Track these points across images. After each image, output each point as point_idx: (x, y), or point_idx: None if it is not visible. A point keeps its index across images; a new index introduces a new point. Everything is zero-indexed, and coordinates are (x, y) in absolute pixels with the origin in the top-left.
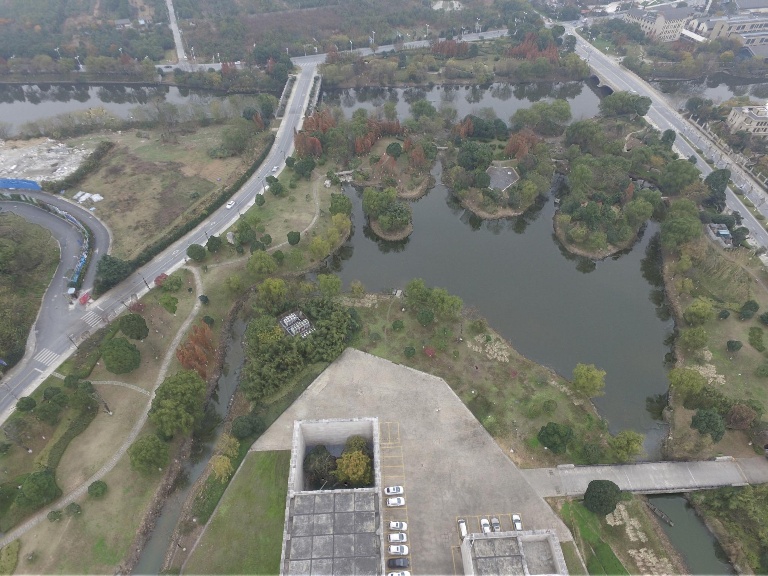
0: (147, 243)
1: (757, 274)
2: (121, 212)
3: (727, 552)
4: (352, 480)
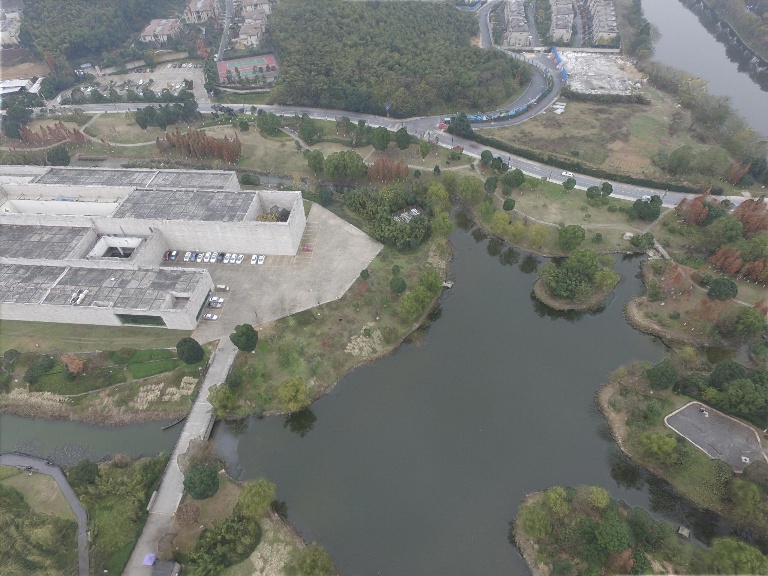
0: (504, 140)
1: None
2: (542, 124)
3: None
4: None
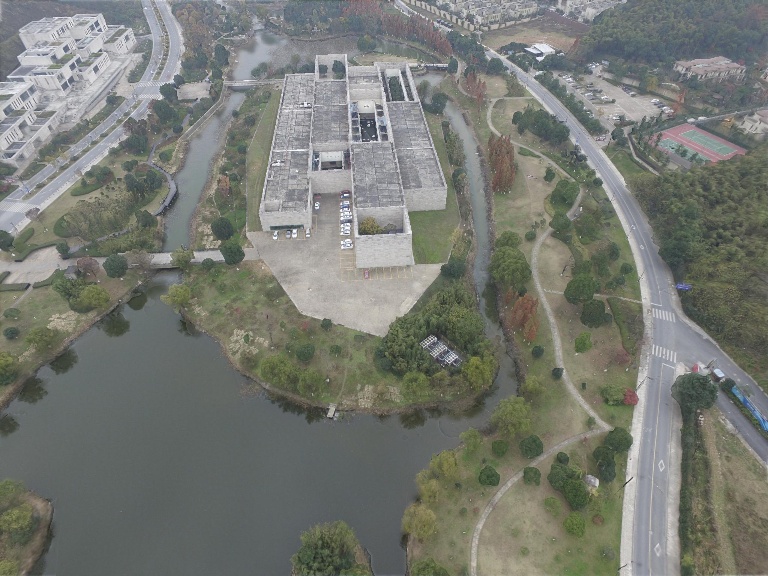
0: (720, 479)
1: None
2: None
3: None
4: None
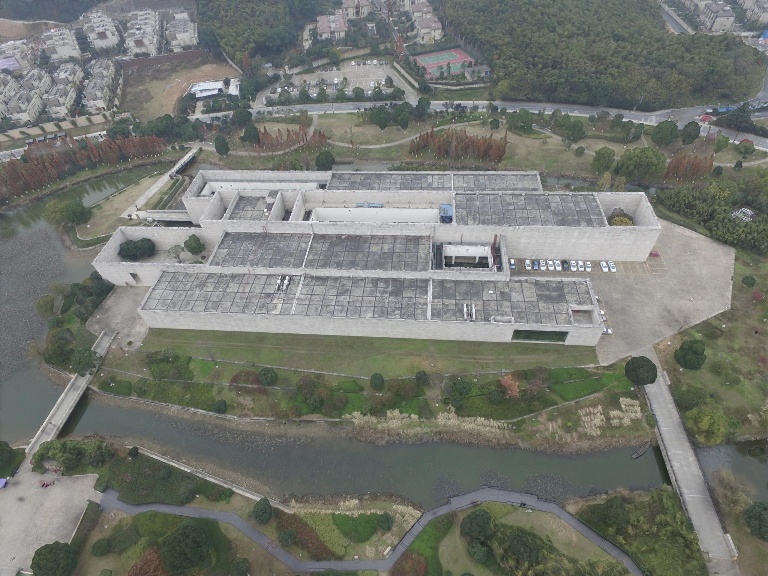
0: None
1: None
2: None
3: None
4: None
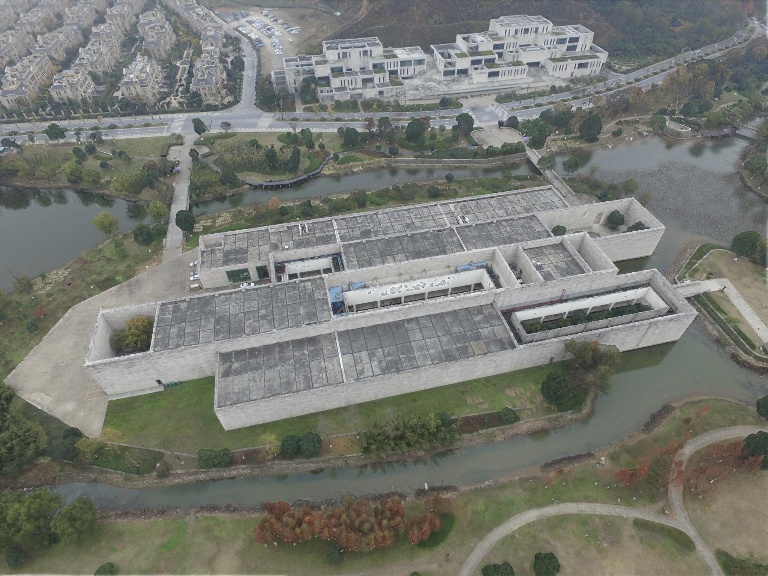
0: None
1: (50, 148)
2: None
3: (221, 196)
4: (148, 328)
